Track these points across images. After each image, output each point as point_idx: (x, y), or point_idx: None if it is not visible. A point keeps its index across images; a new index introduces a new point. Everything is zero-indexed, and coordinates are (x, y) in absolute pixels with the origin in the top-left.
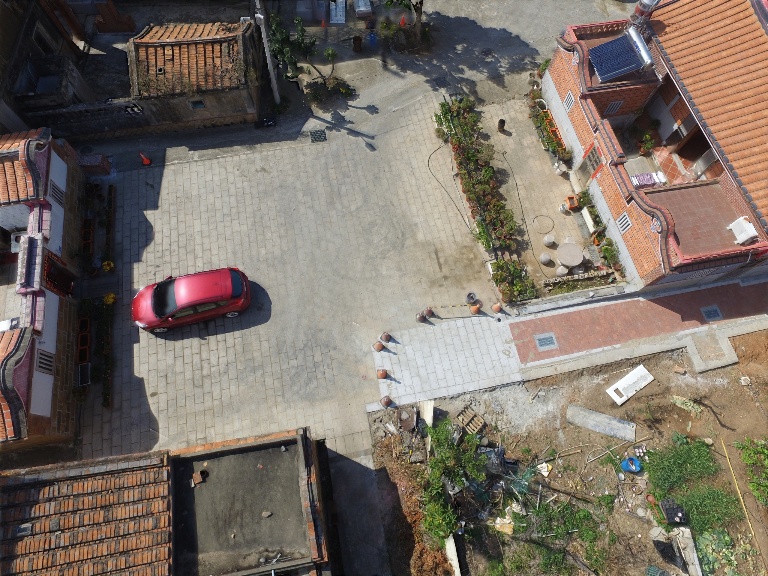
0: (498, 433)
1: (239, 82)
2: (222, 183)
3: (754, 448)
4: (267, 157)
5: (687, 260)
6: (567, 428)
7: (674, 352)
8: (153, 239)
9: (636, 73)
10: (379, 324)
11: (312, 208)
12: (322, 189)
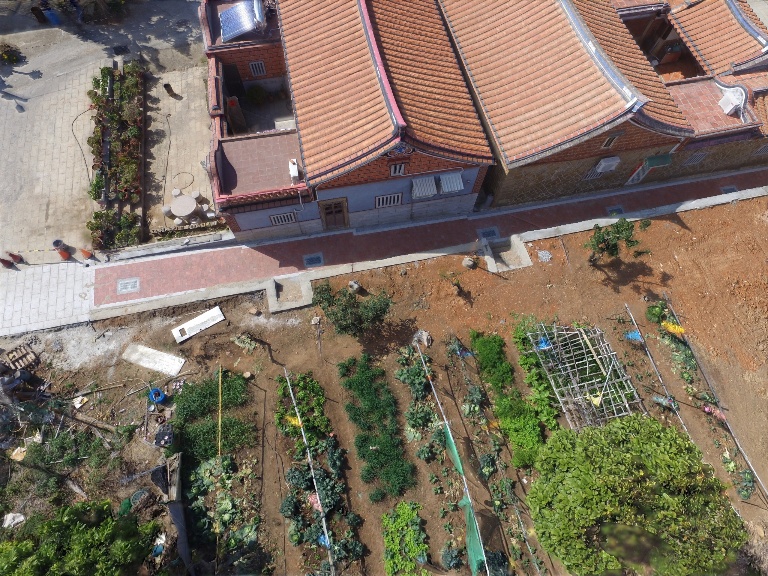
0: (50, 370)
1: None
2: None
3: (293, 381)
4: None
5: (221, 199)
6: (120, 365)
7: (255, 295)
8: None
9: (256, 33)
10: None
11: None
12: None
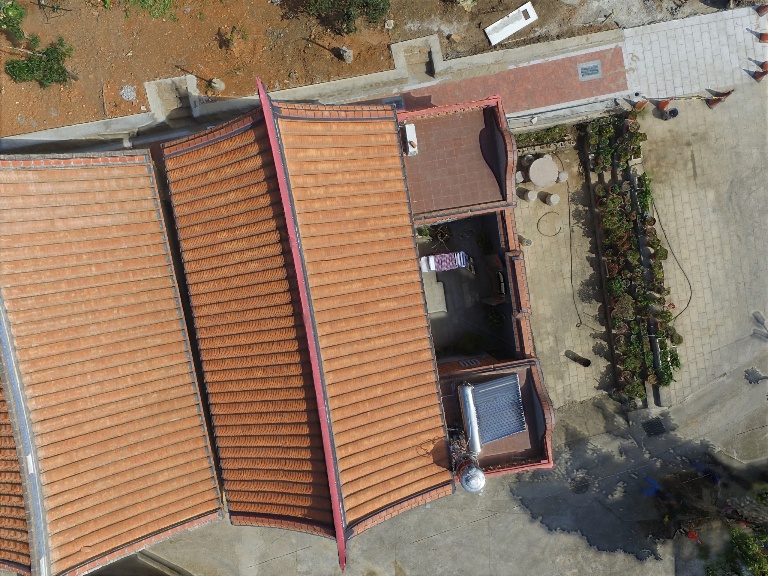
0: None
1: None
2: None
3: None
4: None
5: (495, 98)
6: None
7: None
8: None
9: None
10: (764, 91)
11: None
12: None
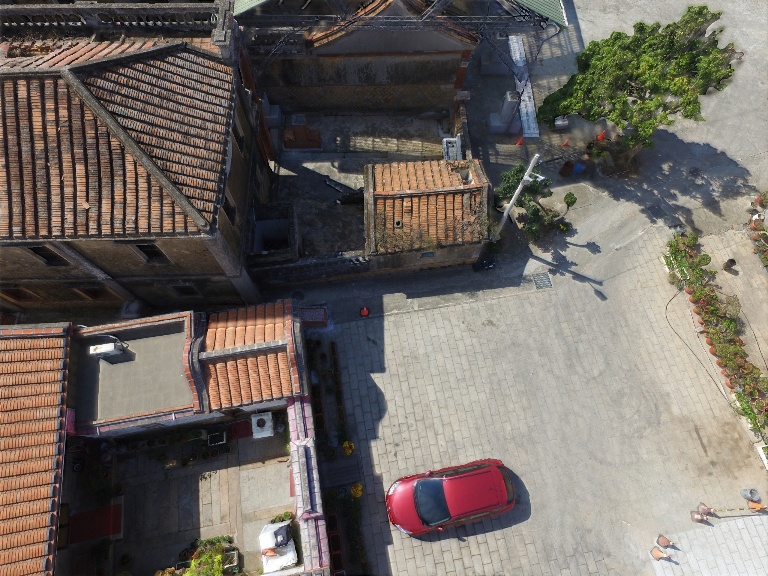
0: None
1: (481, 236)
2: (449, 339)
3: None
4: (492, 307)
5: None
6: None
7: None
8: (386, 410)
9: None
10: (652, 524)
11: (552, 372)
12: (558, 348)
